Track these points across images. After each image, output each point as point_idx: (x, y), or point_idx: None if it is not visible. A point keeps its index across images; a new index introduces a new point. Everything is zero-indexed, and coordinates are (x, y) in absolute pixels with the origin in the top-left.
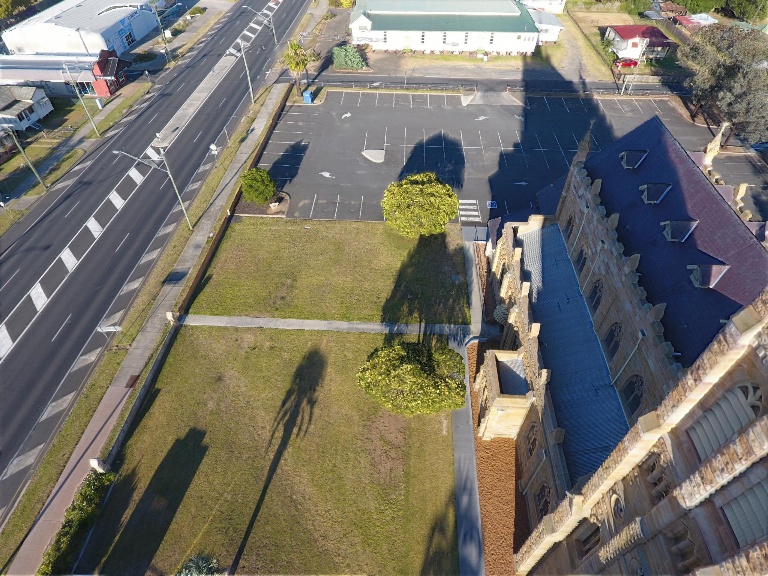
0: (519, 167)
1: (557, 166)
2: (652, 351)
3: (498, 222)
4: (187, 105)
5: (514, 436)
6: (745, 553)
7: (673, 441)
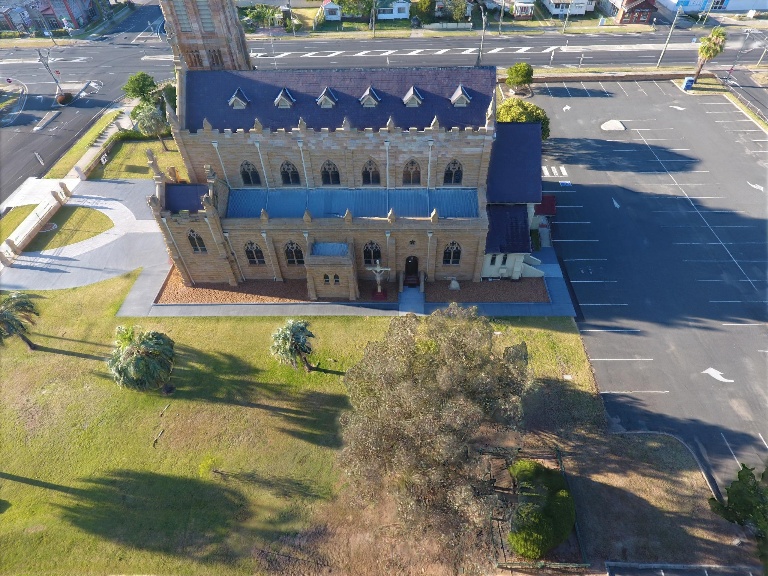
0: (651, 205)
1: (673, 233)
2: None
3: None
4: (627, 45)
5: None
6: None
7: None
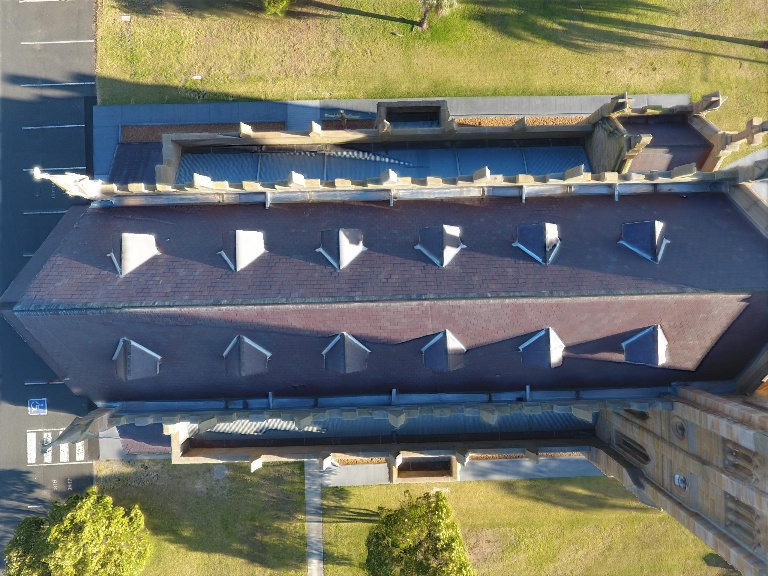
0: None
1: None
2: None
3: (133, 443)
4: None
5: None
6: None
7: None
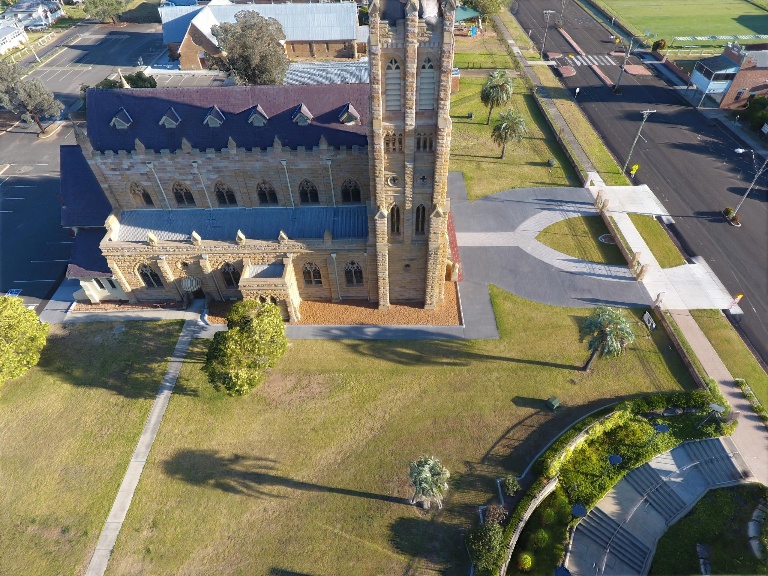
0: None
1: None
2: (297, 160)
3: (75, 267)
4: None
5: (299, 300)
6: (440, 100)
7: (386, 121)
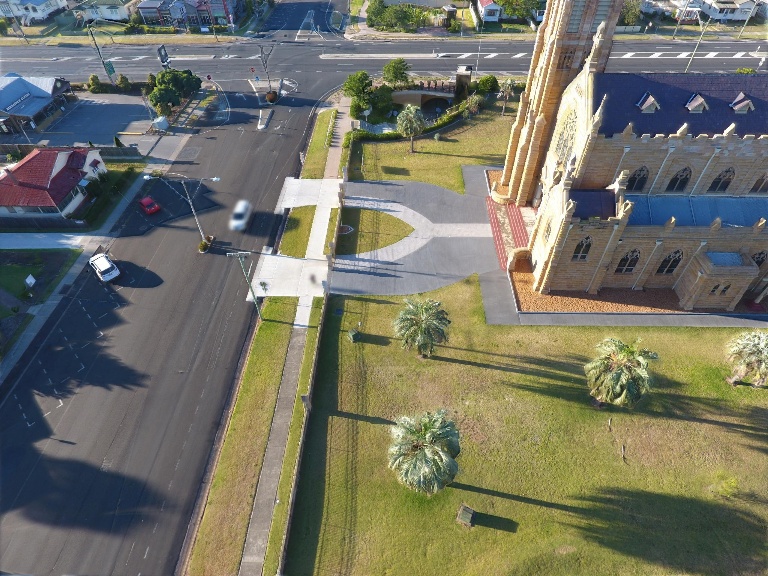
0: None
1: None
2: None
3: None
4: None
5: None
6: None
7: None
